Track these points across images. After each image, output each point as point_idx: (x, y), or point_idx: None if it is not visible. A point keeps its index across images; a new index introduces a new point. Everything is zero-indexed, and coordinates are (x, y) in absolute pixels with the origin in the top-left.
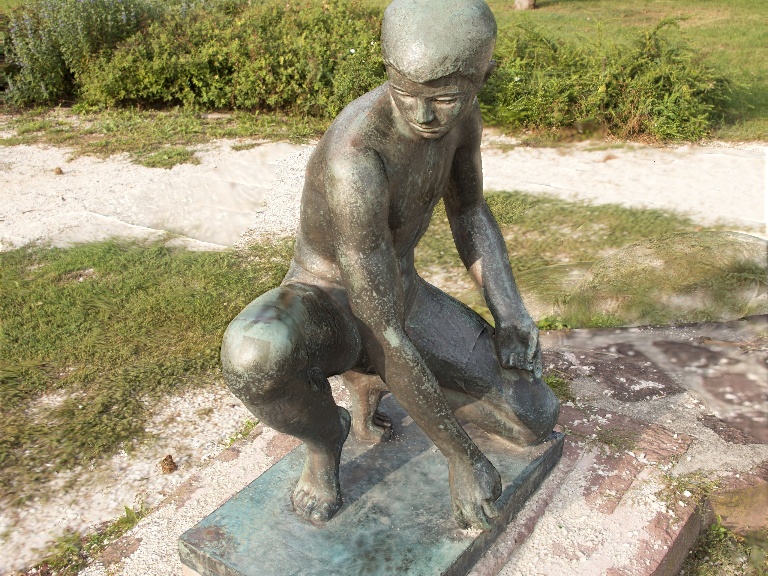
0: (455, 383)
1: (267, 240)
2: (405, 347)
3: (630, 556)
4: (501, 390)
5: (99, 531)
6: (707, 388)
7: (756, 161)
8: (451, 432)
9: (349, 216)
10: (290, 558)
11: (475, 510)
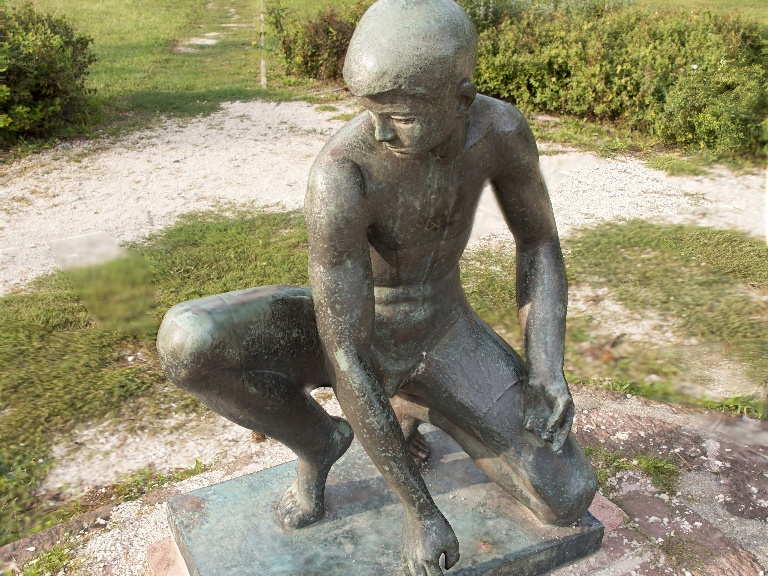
0: (472, 431)
1: (501, 248)
2: (353, 374)
3: None
4: (520, 453)
5: (170, 474)
6: None
7: None
8: (397, 477)
9: (313, 226)
10: (238, 551)
11: (415, 568)
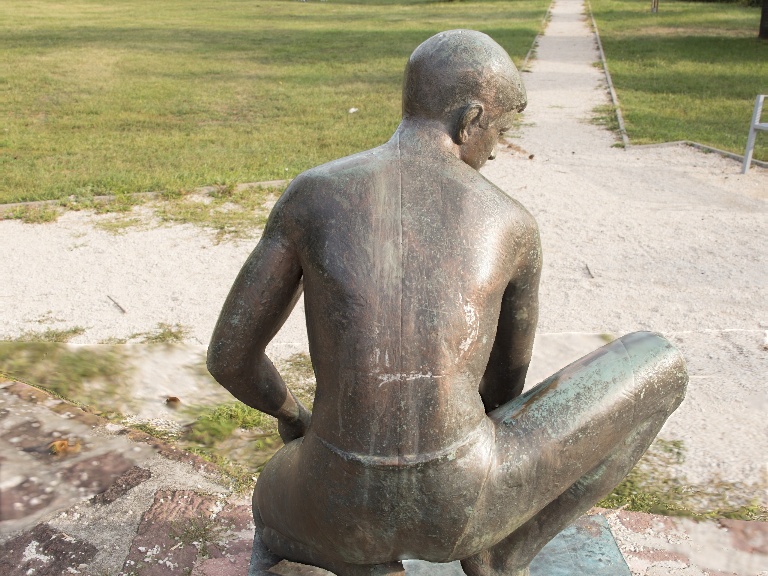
0: None
1: None
2: None
3: None
4: None
5: None
6: (23, 516)
7: None
8: None
9: None
10: None
11: None
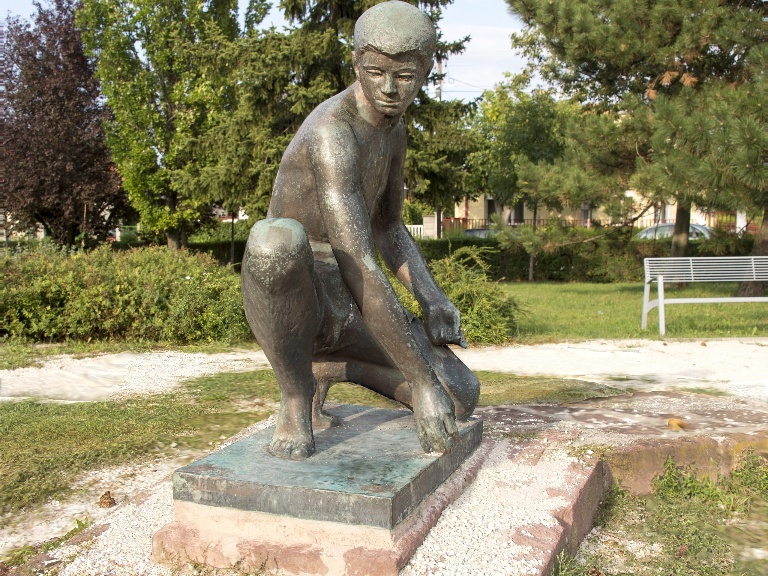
0: None
1: (138, 397)
2: (380, 271)
3: (560, 482)
4: (434, 364)
5: None
6: (577, 420)
7: (552, 350)
8: (416, 351)
9: (335, 164)
10: (285, 472)
11: (439, 425)
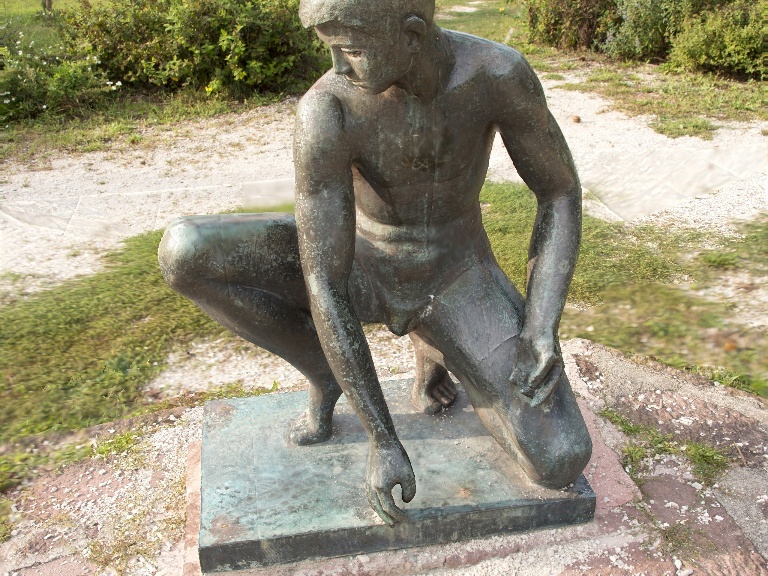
0: (469, 378)
1: (669, 225)
2: (321, 298)
3: None
4: (508, 405)
5: (252, 391)
6: None
7: None
8: (357, 402)
9: (295, 154)
10: (240, 454)
11: (370, 493)
